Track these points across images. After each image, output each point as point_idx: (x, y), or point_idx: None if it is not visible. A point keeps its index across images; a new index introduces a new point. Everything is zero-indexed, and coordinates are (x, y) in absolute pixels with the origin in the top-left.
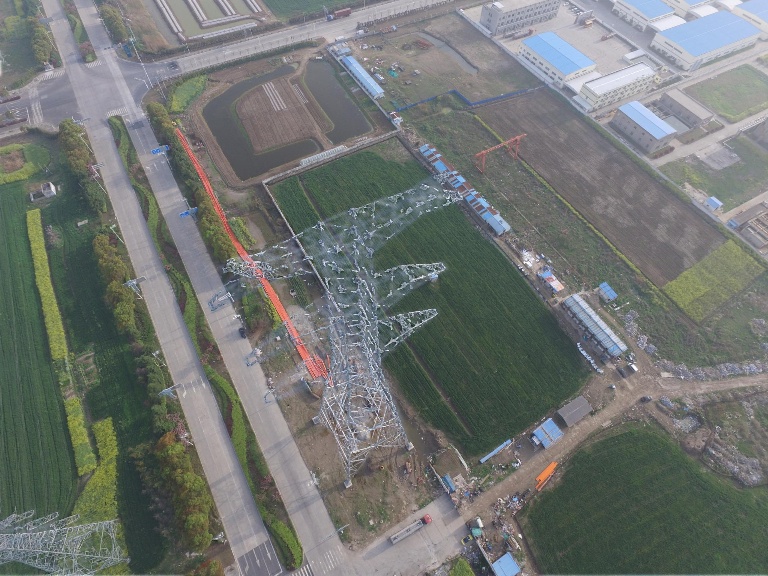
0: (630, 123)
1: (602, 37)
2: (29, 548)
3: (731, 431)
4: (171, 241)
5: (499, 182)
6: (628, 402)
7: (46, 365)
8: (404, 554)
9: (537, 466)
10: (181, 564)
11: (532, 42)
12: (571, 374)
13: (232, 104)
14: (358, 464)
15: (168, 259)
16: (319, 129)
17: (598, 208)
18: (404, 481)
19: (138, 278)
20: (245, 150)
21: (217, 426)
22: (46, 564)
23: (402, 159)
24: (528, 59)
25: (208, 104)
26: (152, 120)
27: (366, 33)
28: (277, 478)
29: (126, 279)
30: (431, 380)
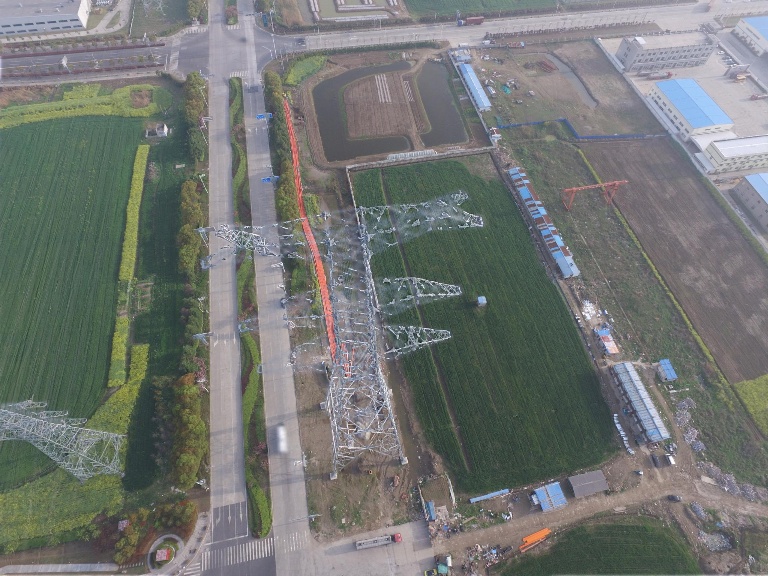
0: (754, 196)
1: (752, 96)
2: (40, 434)
3: (767, 568)
4: (248, 201)
5: (583, 224)
6: (652, 494)
7: (112, 282)
8: (365, 563)
9: (528, 526)
10: (164, 495)
11: (667, 86)
12: (597, 444)
13: (342, 88)
14: (346, 460)
15: (240, 217)
16: (415, 129)
17: (686, 278)
18: (388, 492)
19: (208, 227)
20: (340, 133)
21: (234, 381)
22: (53, 453)
23: (488, 176)
24: (657, 103)
25: (320, 83)
26: (266, 87)
27: (492, 44)
28: (271, 447)
29: (200, 225)
30: (446, 403)
